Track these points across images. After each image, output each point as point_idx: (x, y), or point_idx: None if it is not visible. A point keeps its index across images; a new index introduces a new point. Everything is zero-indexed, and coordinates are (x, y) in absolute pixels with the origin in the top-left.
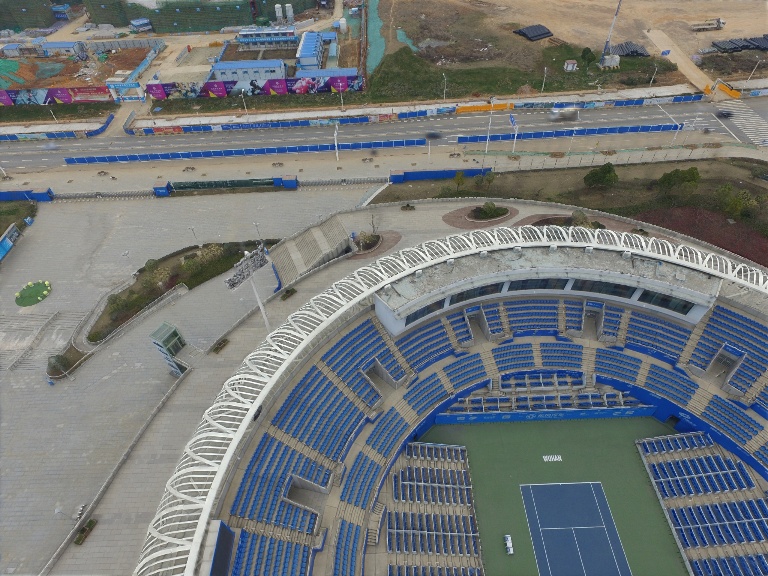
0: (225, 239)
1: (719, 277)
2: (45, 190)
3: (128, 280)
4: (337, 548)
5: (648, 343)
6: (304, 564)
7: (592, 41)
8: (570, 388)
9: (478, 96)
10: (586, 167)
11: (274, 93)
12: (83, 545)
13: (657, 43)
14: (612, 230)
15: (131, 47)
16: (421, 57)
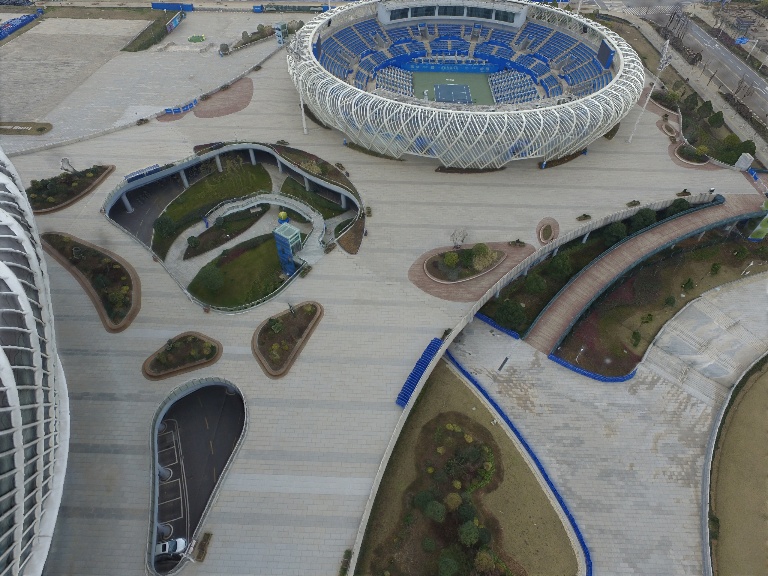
0: None
1: (527, 4)
2: (190, 4)
3: None
4: (357, 74)
5: None
6: None
7: None
8: (462, 58)
9: None
10: None
11: None
12: (258, 71)
13: None
14: None
15: None
16: None
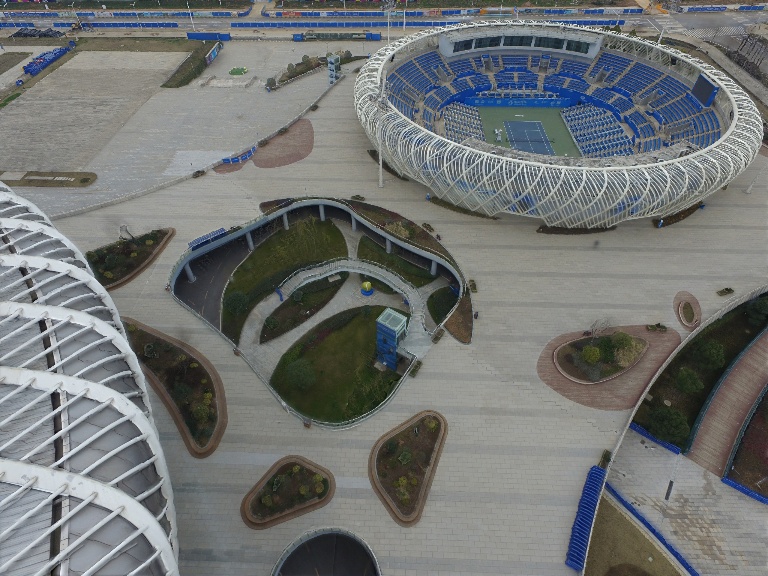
0: None
1: (603, 34)
2: (227, 33)
3: None
4: None
5: None
6: None
7: None
8: (531, 92)
9: (495, 7)
10: None
11: None
12: (315, 111)
13: None
14: None
15: None
16: None
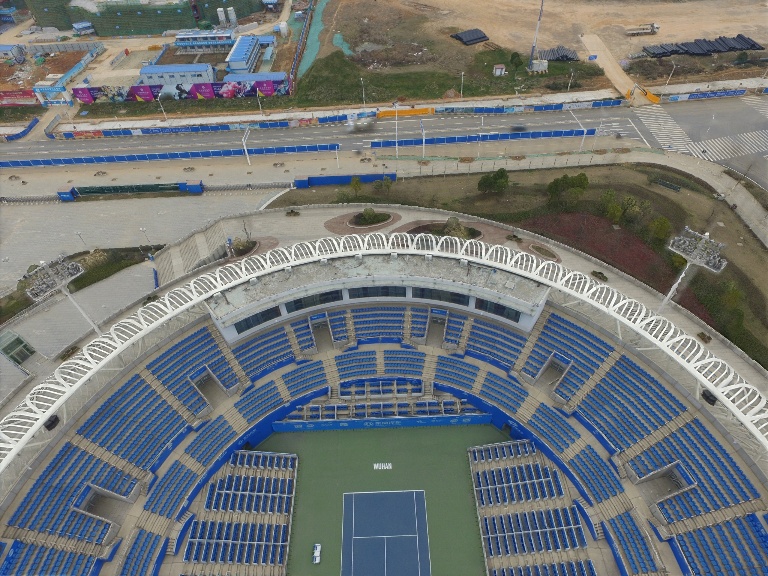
0: (119, 244)
1: (547, 285)
2: None
3: (13, 286)
4: (128, 558)
5: (487, 351)
6: (85, 575)
7: (526, 45)
8: (409, 396)
9: (403, 100)
10: (492, 172)
11: (201, 97)
12: None
13: (589, 48)
14: (488, 236)
15: (70, 50)
16: (353, 61)
